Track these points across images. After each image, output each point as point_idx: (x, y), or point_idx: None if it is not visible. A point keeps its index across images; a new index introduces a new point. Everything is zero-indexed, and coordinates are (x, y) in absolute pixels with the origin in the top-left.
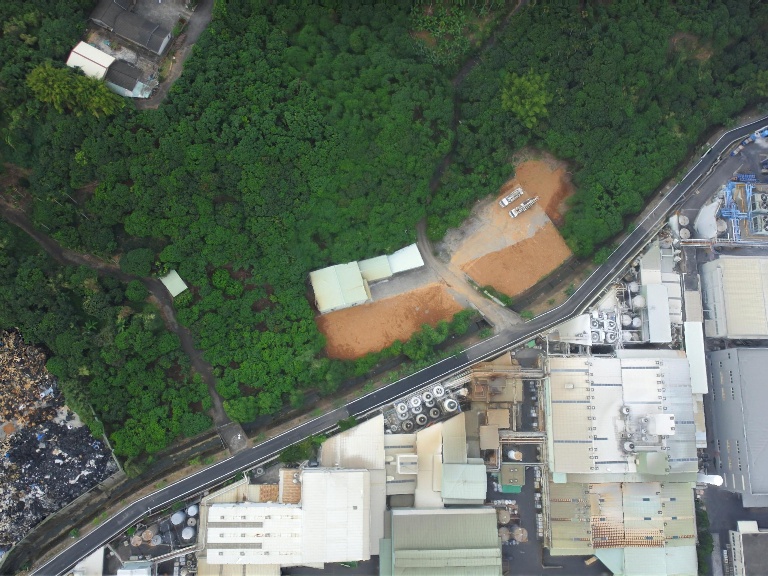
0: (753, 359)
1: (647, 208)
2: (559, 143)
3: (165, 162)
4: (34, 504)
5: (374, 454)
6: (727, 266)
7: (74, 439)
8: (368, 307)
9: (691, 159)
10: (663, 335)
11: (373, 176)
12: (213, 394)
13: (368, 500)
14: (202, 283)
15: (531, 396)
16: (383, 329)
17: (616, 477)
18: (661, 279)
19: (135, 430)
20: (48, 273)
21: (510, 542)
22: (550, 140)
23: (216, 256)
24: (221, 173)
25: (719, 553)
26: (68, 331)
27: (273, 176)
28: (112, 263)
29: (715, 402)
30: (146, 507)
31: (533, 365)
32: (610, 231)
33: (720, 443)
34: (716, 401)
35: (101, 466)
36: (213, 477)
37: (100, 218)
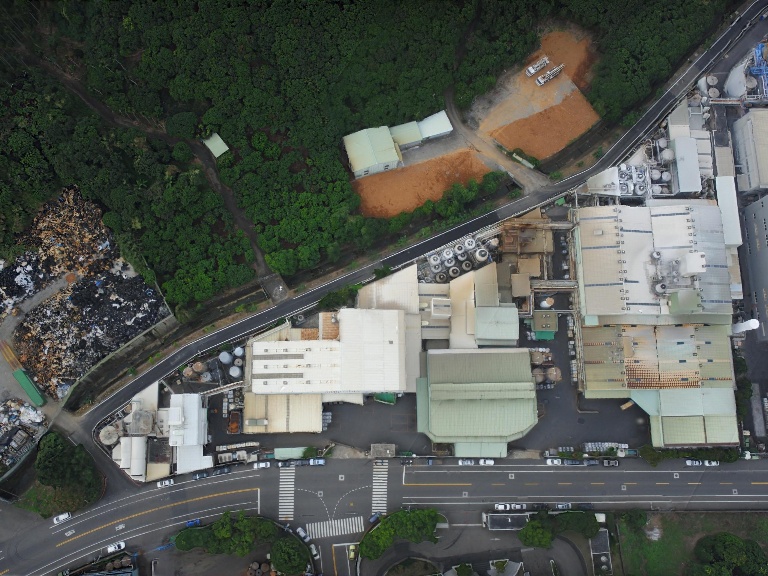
0: None
1: (675, 75)
2: (583, 9)
3: (204, 25)
4: (95, 342)
5: (409, 299)
6: (757, 118)
7: (129, 285)
8: (400, 171)
9: (719, 27)
10: (693, 184)
11: (400, 41)
12: (255, 249)
13: (403, 336)
14: (242, 144)
15: (562, 250)
16: (415, 191)
17: (649, 319)
18: (690, 133)
19: (184, 280)
20: (102, 132)
21: (545, 386)
22: (573, 6)
23: (254, 118)
24: (256, 36)
25: (759, 402)
26: (121, 186)
27: (305, 38)
28: (159, 128)
29: (750, 255)
30: (196, 350)
31: (563, 219)
32: (637, 94)
33: (757, 294)
34: (751, 254)
35: (154, 309)
36: (257, 324)
37: (147, 83)
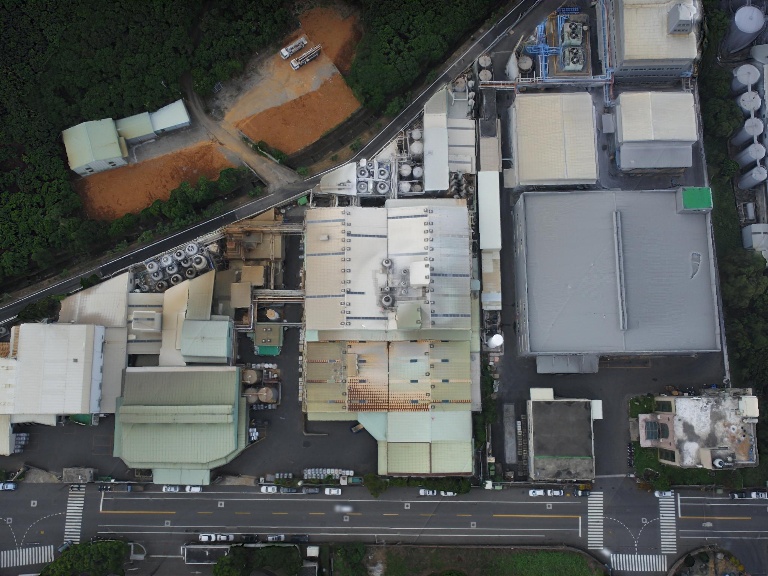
0: (568, 214)
1: (455, 54)
2: None
3: None
4: None
5: (114, 311)
6: (523, 105)
7: None
8: (132, 168)
9: None
10: (439, 182)
11: (118, 24)
12: None
13: (91, 353)
14: None
15: (299, 255)
16: (146, 190)
17: (376, 335)
18: (446, 123)
19: None
20: None
21: (265, 406)
22: None
23: None
24: None
25: (513, 425)
26: None
27: None
28: None
29: None
30: None
31: (299, 221)
32: (402, 78)
33: (518, 305)
34: None
35: None
36: None
37: None
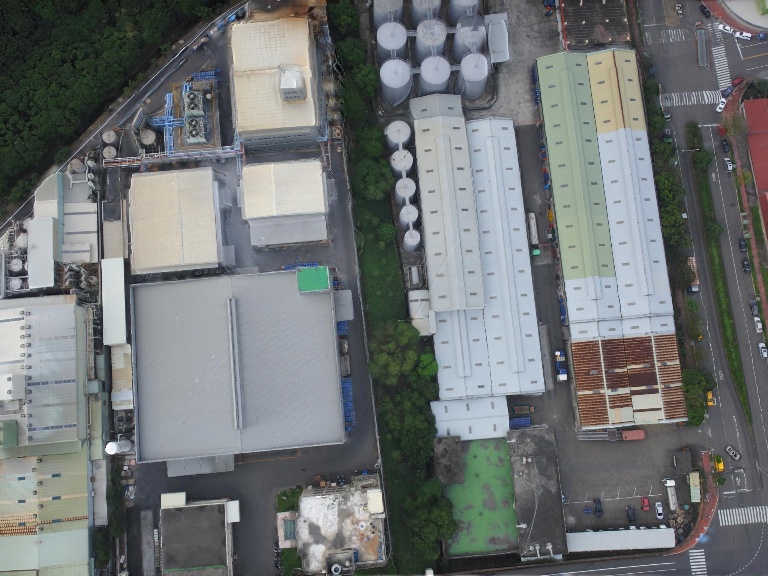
0: (210, 296)
1: (91, 128)
2: None
3: None
4: None
5: None
6: (138, 186)
7: None
8: None
9: (153, 62)
10: (43, 278)
11: None
12: None
13: None
14: None
15: None
16: None
17: None
18: (57, 211)
19: None
20: None
21: None
22: None
23: None
24: None
25: (151, 533)
26: None
27: None
28: None
29: None
30: None
31: None
32: (24, 160)
33: None
34: None
35: None
36: None
37: None
